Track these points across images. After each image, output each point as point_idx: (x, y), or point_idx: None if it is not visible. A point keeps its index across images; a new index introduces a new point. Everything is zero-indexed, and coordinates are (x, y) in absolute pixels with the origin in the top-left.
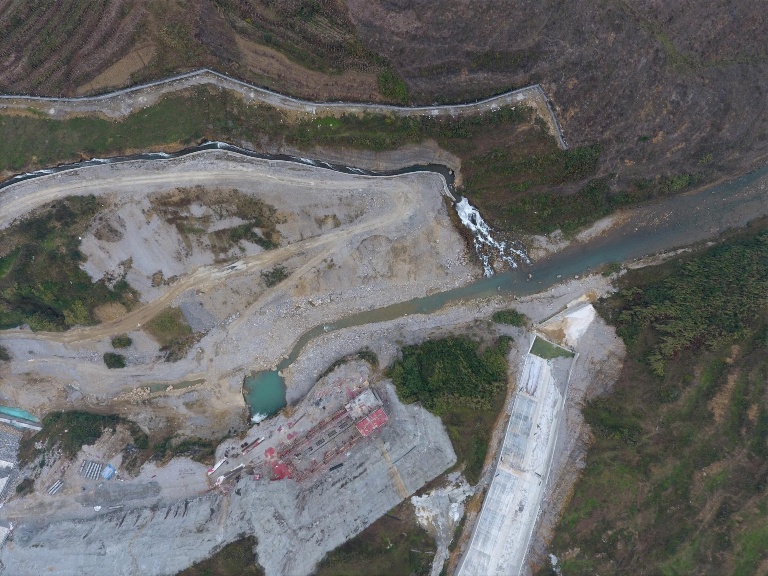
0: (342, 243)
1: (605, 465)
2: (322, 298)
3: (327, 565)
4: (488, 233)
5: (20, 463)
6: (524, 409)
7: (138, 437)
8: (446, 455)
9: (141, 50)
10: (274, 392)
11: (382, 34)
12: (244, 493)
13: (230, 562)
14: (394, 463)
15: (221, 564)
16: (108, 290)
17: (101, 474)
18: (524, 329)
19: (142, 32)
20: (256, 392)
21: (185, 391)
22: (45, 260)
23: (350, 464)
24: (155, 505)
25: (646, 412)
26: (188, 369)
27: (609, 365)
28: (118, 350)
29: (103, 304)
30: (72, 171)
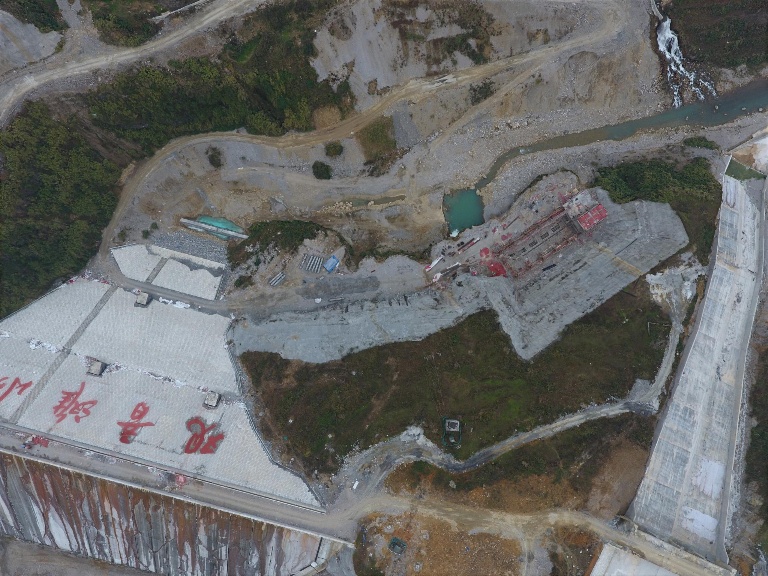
0: (550, 59)
1: None
2: (520, 121)
3: (571, 332)
4: (681, 62)
5: (232, 265)
6: (728, 218)
7: None
8: (676, 239)
9: None
10: (471, 211)
11: None
12: (467, 284)
13: (476, 328)
14: (616, 254)
15: (467, 331)
16: (332, 90)
17: (322, 267)
18: (718, 151)
19: None
20: (454, 210)
21: (387, 206)
22: (283, 50)
23: (564, 263)
24: (375, 298)
25: None
26: (390, 184)
27: None
28: (327, 159)
29: (323, 106)
30: None
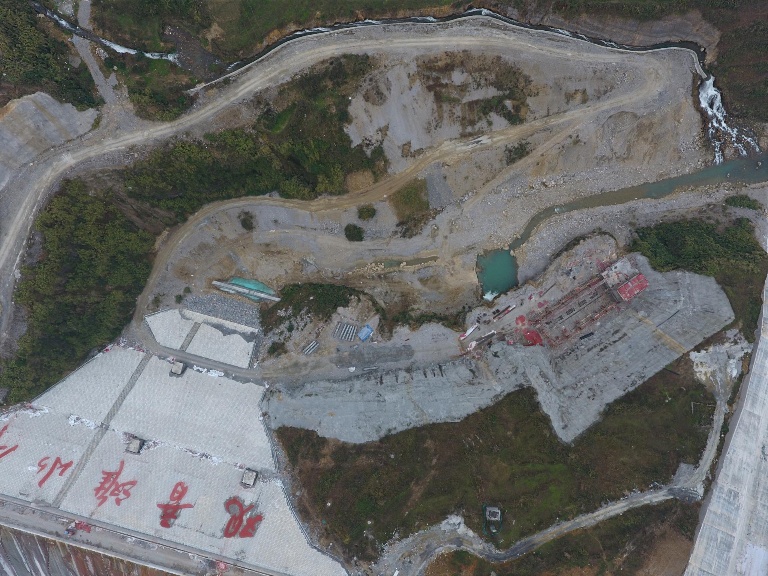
0: (588, 119)
1: None
2: (555, 179)
3: (612, 413)
4: (723, 118)
5: (264, 329)
6: None
7: (378, 308)
8: (720, 314)
9: None
10: (504, 272)
11: None
12: (503, 355)
13: (515, 408)
14: (658, 326)
15: (506, 410)
16: (366, 155)
17: (356, 336)
18: (761, 212)
19: None
20: (487, 271)
21: (419, 267)
22: (317, 118)
23: (602, 332)
24: (409, 368)
25: None
26: (423, 245)
27: None
28: (360, 222)
29: (357, 171)
30: (347, 30)
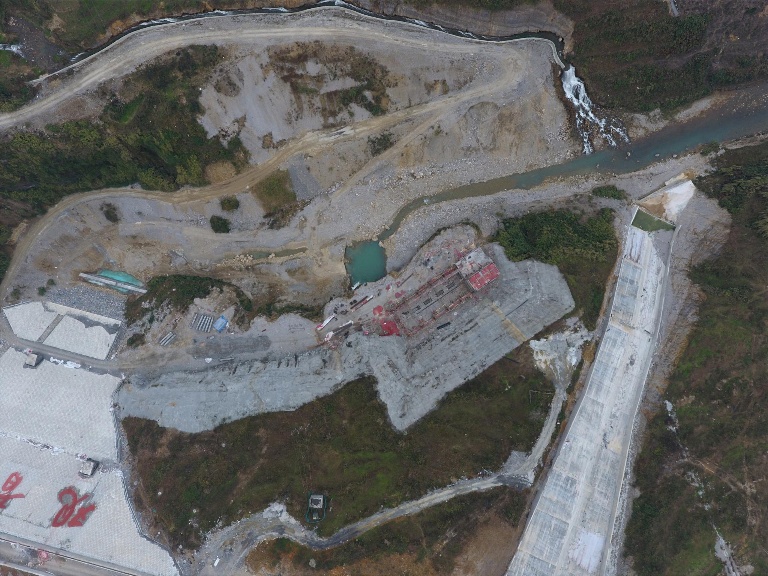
0: (450, 110)
1: (718, 318)
2: (424, 170)
3: (449, 402)
4: (590, 108)
5: (128, 321)
6: (629, 274)
7: (243, 299)
8: (563, 303)
9: None
10: (374, 263)
11: None
12: (356, 345)
13: (353, 397)
14: (507, 316)
15: (343, 399)
16: (222, 146)
17: (213, 327)
18: (625, 202)
19: None
20: (356, 262)
21: (287, 259)
22: (167, 109)
23: (458, 322)
24: (265, 358)
25: (756, 271)
26: (291, 237)
27: (714, 232)
28: (225, 213)
29: (215, 162)
30: (195, 21)
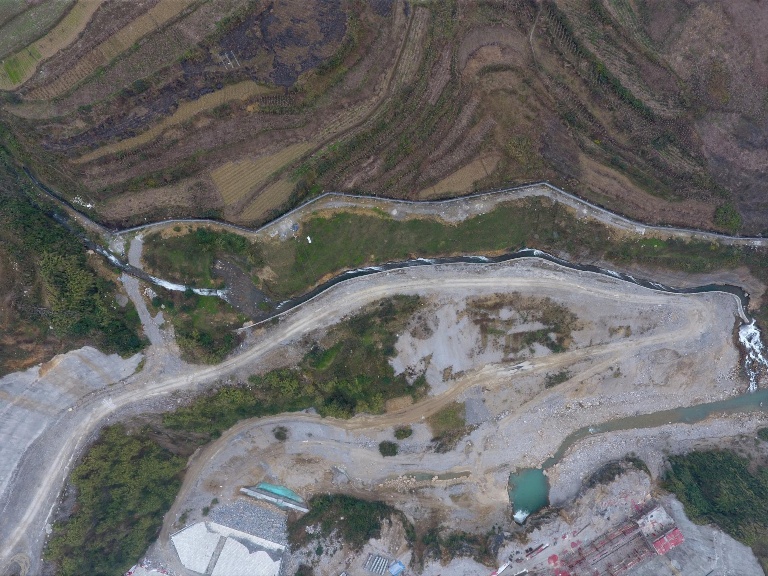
0: (630, 353)
1: None
2: (592, 400)
3: None
4: (760, 351)
5: (291, 546)
6: None
7: None
8: None
9: (485, 159)
10: (536, 490)
11: (732, 169)
12: None
13: None
14: None
15: None
16: (408, 384)
17: (387, 569)
18: None
19: (488, 142)
20: (519, 489)
21: (451, 483)
22: (363, 355)
23: None
24: None
25: None
26: (456, 461)
27: None
28: (395, 439)
29: None
30: (399, 269)
